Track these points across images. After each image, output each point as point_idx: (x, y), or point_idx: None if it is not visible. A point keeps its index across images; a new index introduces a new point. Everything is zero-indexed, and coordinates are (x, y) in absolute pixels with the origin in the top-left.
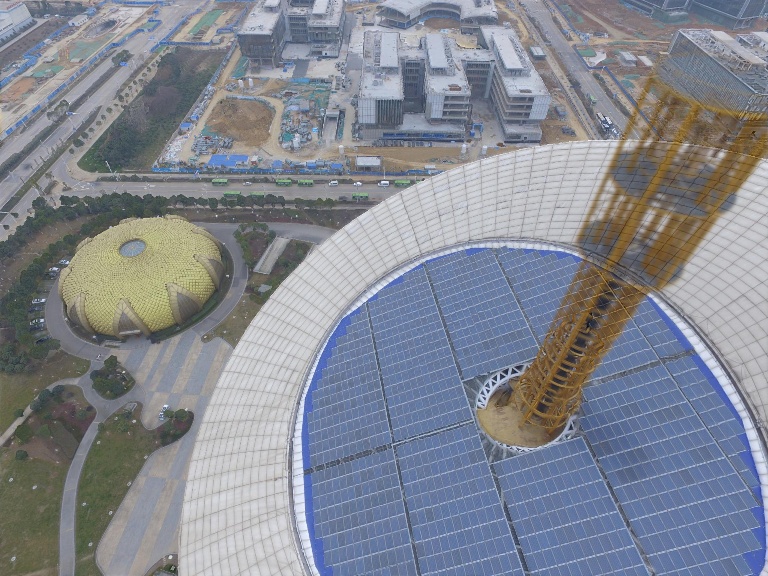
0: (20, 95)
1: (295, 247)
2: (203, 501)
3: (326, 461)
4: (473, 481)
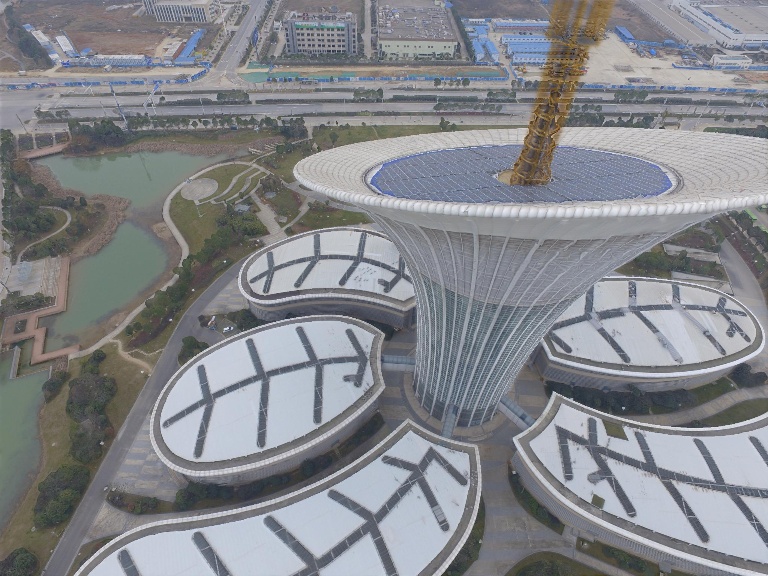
0: (759, 80)
1: (713, 268)
2: (449, 133)
3: (475, 150)
4: (473, 169)
